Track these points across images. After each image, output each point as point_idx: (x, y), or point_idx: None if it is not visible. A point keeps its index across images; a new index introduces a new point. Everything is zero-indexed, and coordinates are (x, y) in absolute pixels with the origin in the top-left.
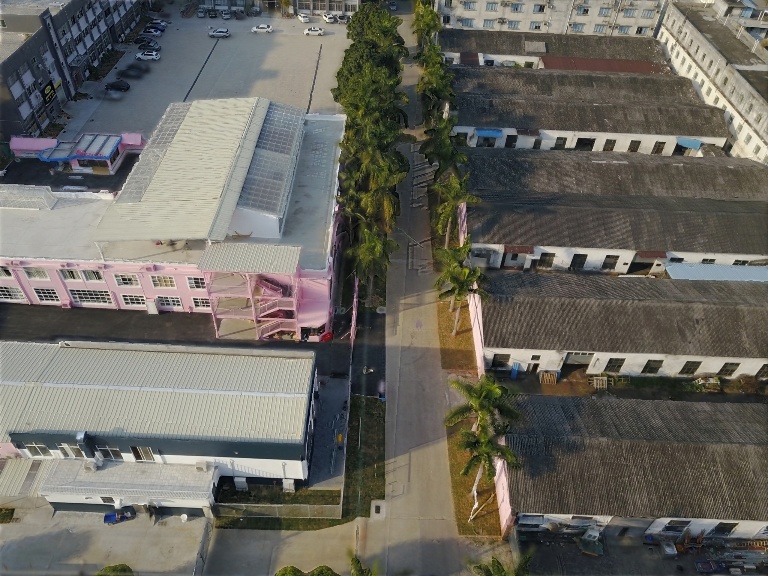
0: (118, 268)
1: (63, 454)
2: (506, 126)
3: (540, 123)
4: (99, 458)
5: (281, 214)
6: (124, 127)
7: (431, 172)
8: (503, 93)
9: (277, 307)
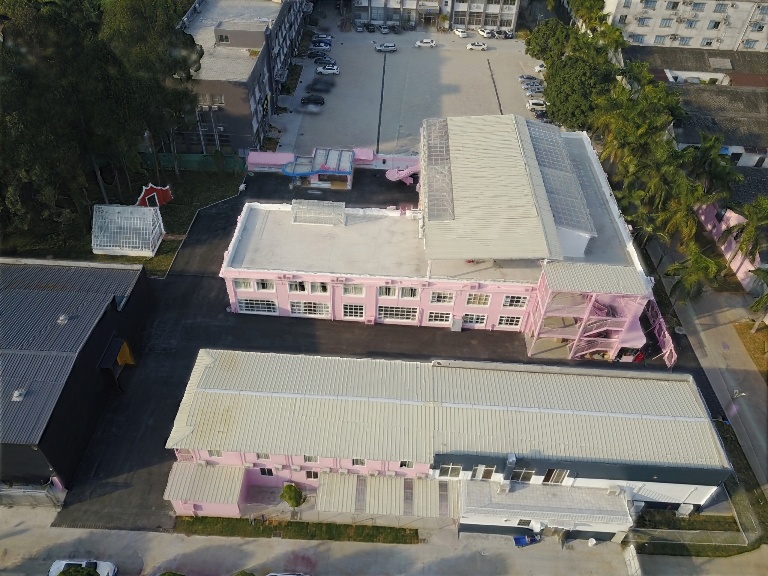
0: (441, 286)
1: (471, 475)
2: (734, 144)
3: (767, 141)
4: None
5: (595, 233)
6: (335, 141)
7: None
8: (711, 110)
9: (606, 327)
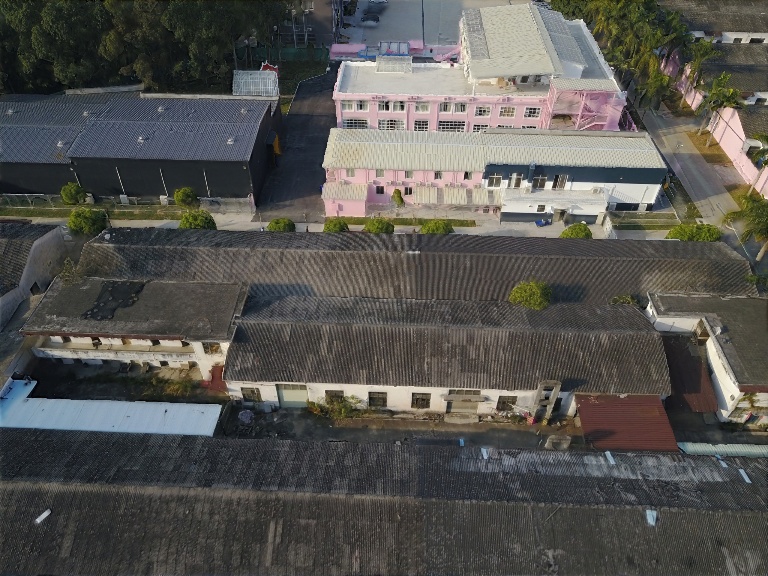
0: (482, 100)
1: (508, 184)
2: (696, 30)
3: (722, 27)
4: (531, 186)
5: (586, 65)
6: None
7: None
8: None
9: (594, 122)
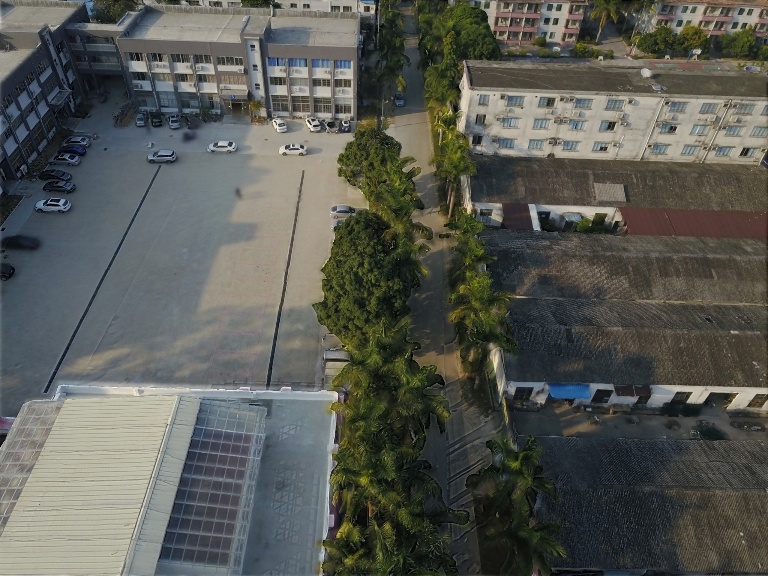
0: None
1: None
2: (597, 381)
3: (651, 372)
4: None
5: None
6: None
7: (477, 463)
8: (578, 293)
9: None
